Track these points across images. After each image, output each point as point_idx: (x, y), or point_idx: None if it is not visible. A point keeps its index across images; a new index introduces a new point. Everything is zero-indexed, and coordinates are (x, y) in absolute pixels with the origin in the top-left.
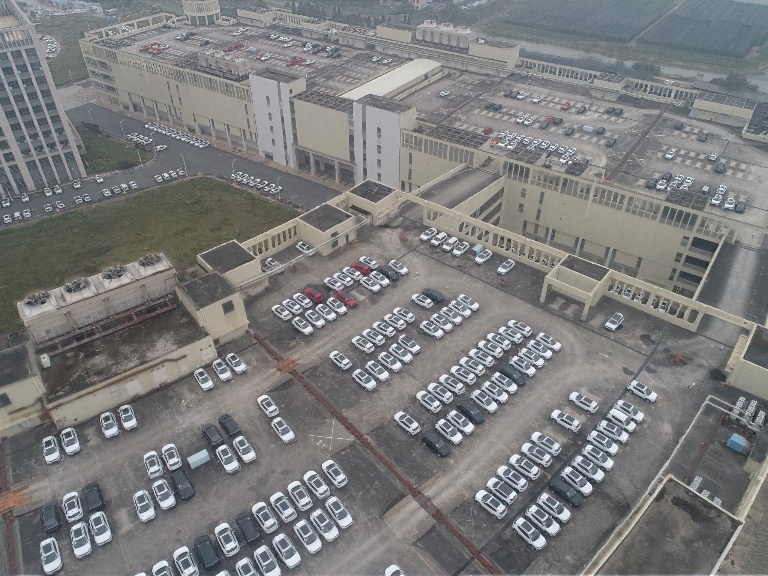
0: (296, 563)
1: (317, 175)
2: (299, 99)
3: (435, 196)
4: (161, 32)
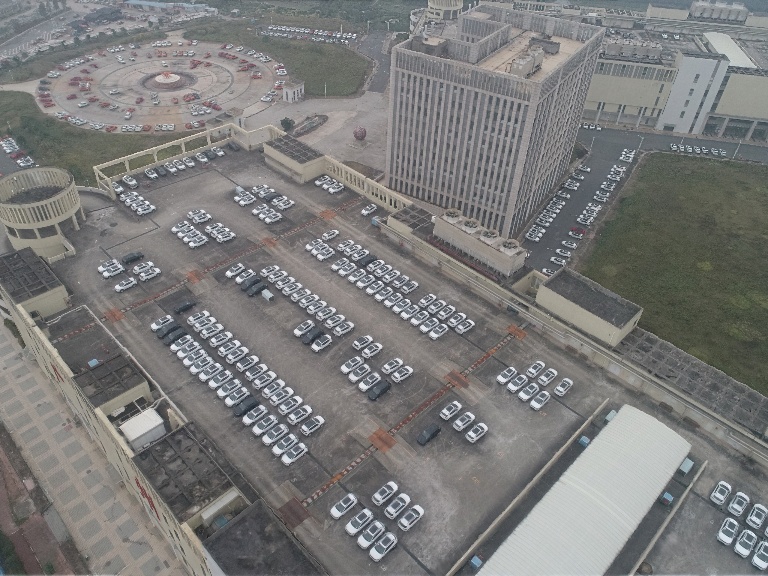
0: None
1: (723, 137)
2: (734, 73)
3: None
4: (439, 28)
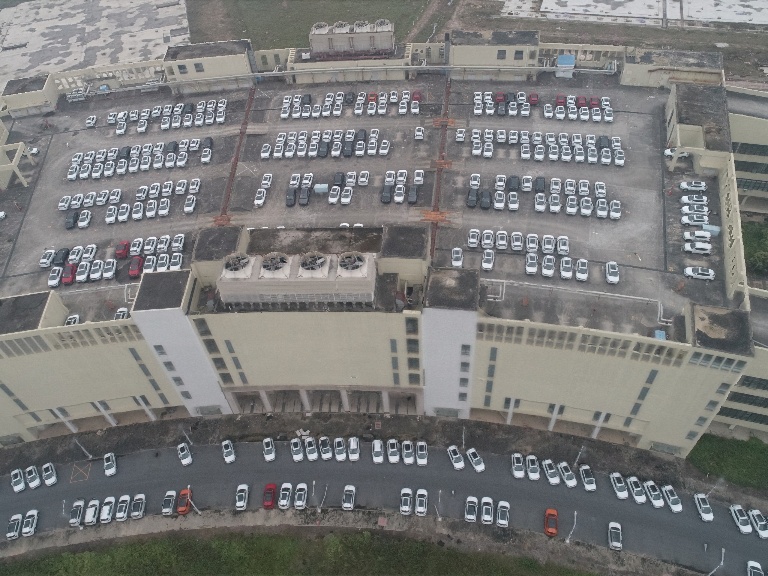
0: None
1: None
2: None
3: None
4: None
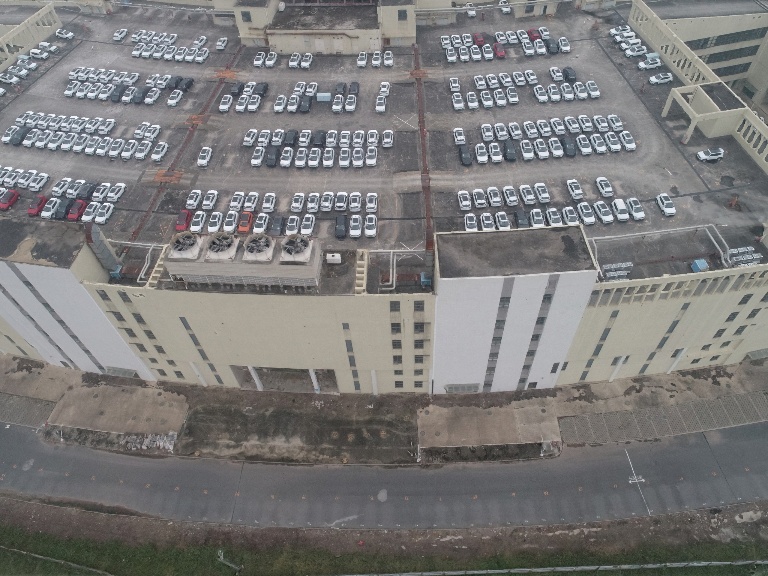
0: (328, 165)
1: None
2: None
3: (671, 6)
4: None
